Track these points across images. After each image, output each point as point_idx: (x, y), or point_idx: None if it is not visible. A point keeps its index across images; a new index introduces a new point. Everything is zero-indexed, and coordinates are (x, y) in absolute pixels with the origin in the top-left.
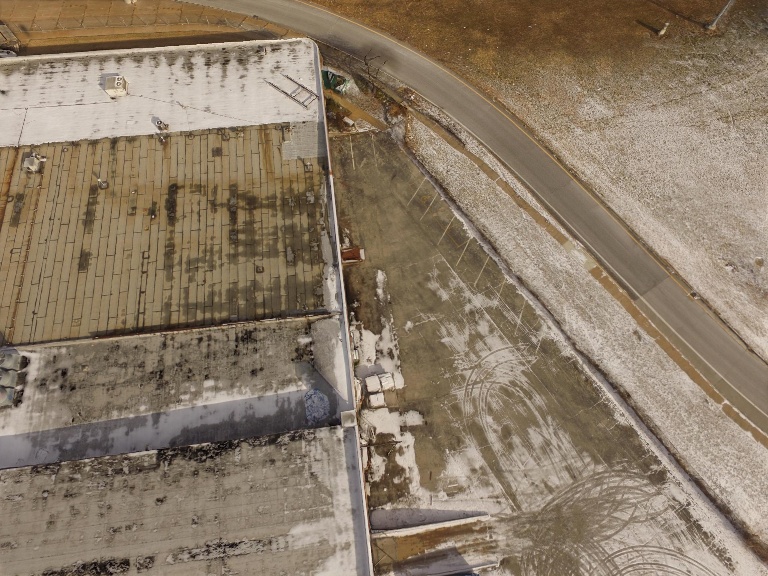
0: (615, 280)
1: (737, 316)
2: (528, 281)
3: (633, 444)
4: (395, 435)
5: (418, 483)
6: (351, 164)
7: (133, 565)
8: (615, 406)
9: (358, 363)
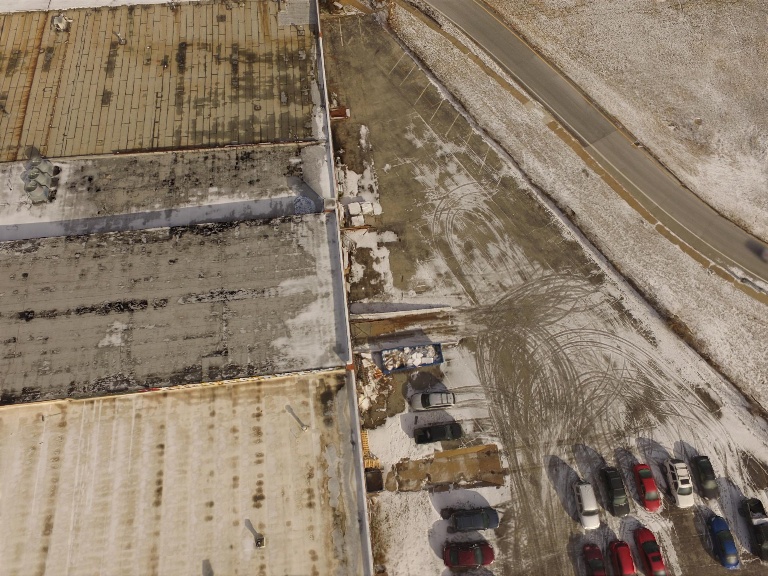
0: (569, 132)
1: (674, 160)
2: (492, 132)
3: (577, 255)
4: (373, 249)
5: (391, 284)
6: (340, 41)
7: (150, 304)
8: (563, 226)
9: (342, 195)
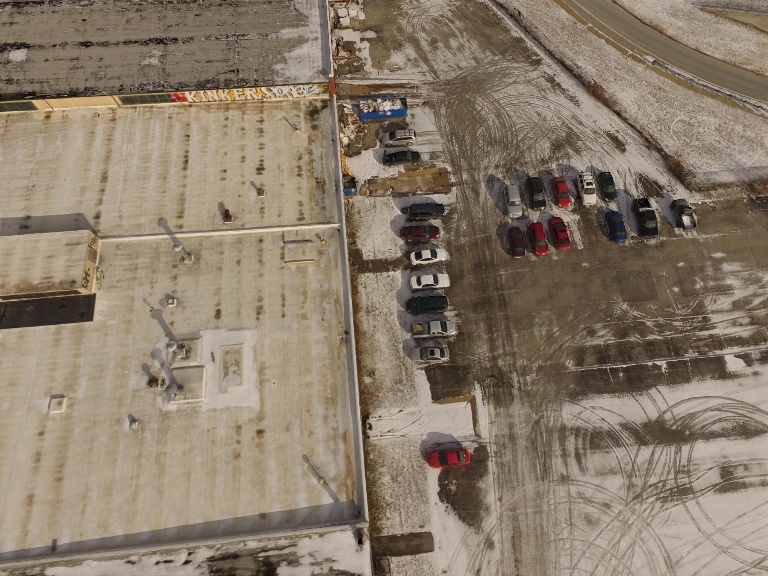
0: None
1: None
2: None
3: (521, 46)
4: (356, 42)
5: (370, 65)
6: None
7: (180, 40)
8: (512, 27)
9: (333, 6)
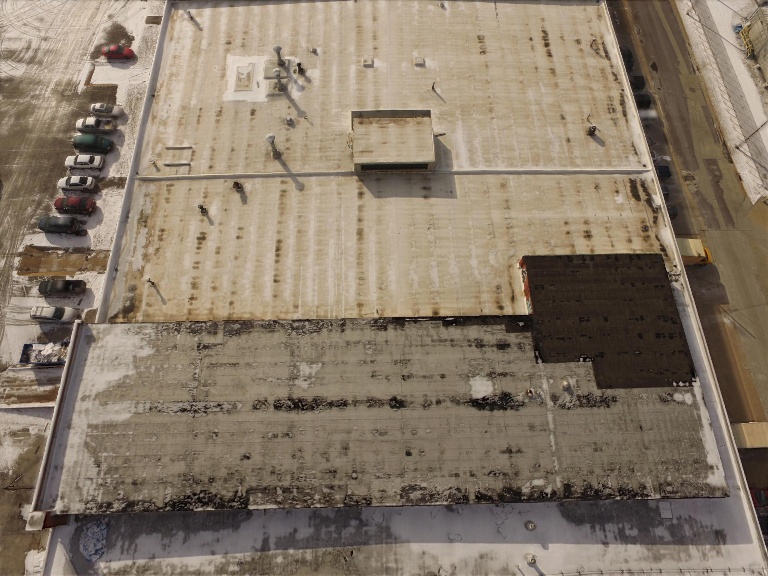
0: None
1: None
2: None
3: None
4: None
5: None
6: None
7: (271, 404)
8: None
9: None
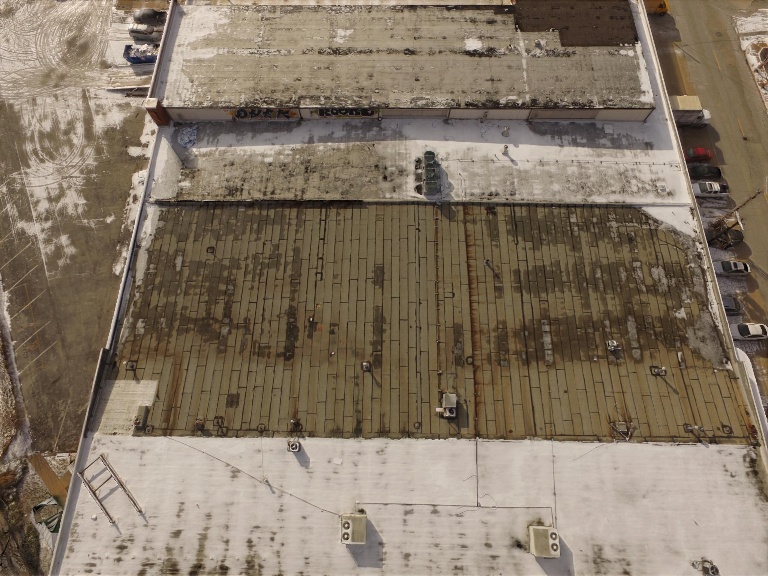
0: None
1: None
2: None
3: None
4: None
5: None
6: None
7: (316, 51)
8: None
9: None
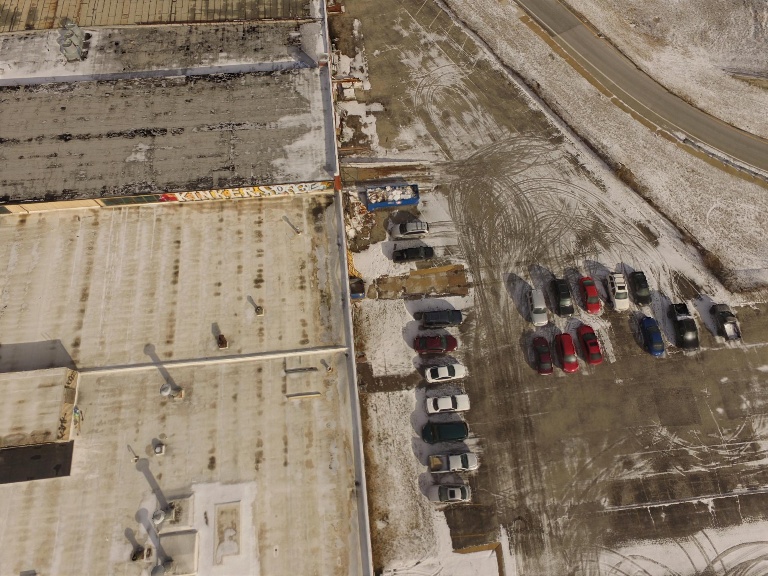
0: (539, 24)
1: (632, 48)
2: (471, 24)
3: (541, 121)
4: (362, 116)
5: (377, 143)
6: None
7: (169, 132)
8: (530, 99)
9: (336, 74)
